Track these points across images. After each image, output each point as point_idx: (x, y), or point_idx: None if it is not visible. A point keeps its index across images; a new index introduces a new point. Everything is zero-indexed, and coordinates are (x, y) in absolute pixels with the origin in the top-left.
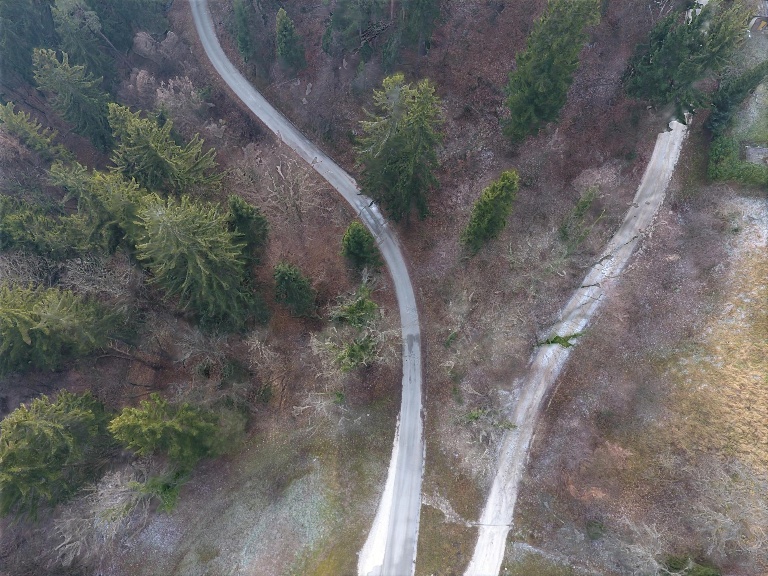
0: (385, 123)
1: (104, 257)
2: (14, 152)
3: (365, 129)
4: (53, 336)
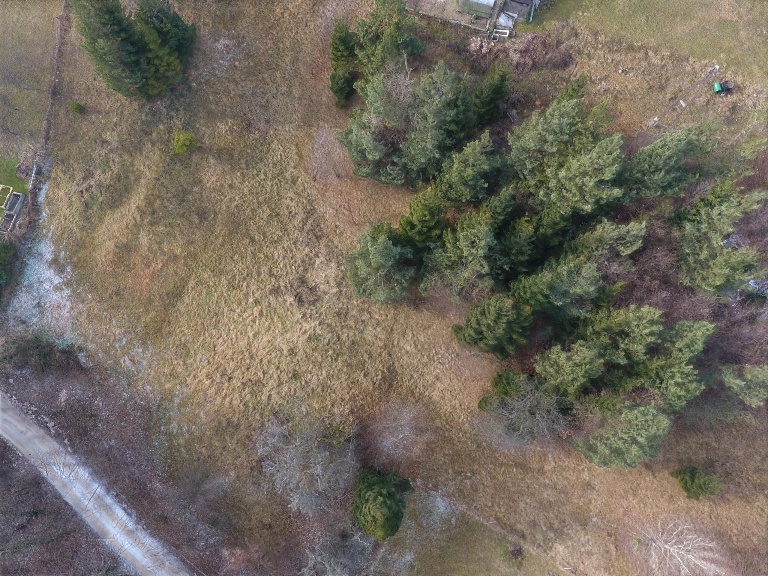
0: None
1: None
2: None
3: None
4: None
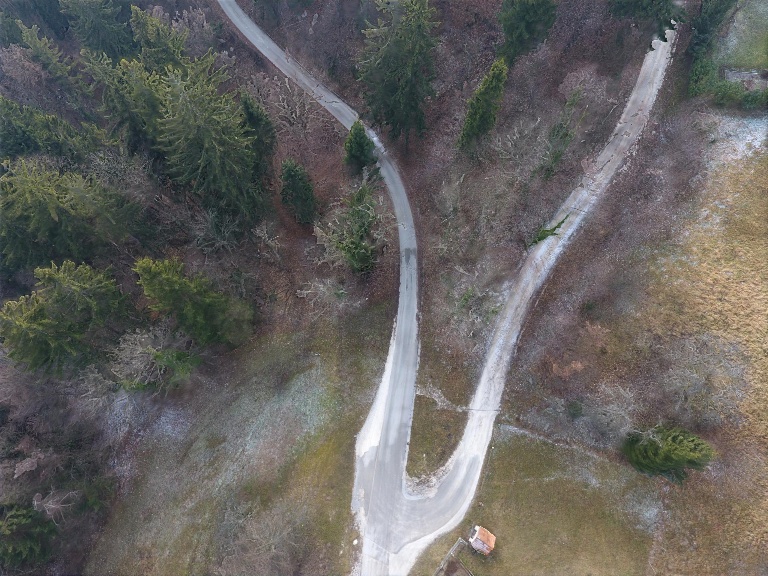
0: (386, 31)
1: (124, 157)
2: (37, 76)
3: (367, 34)
4: (77, 221)
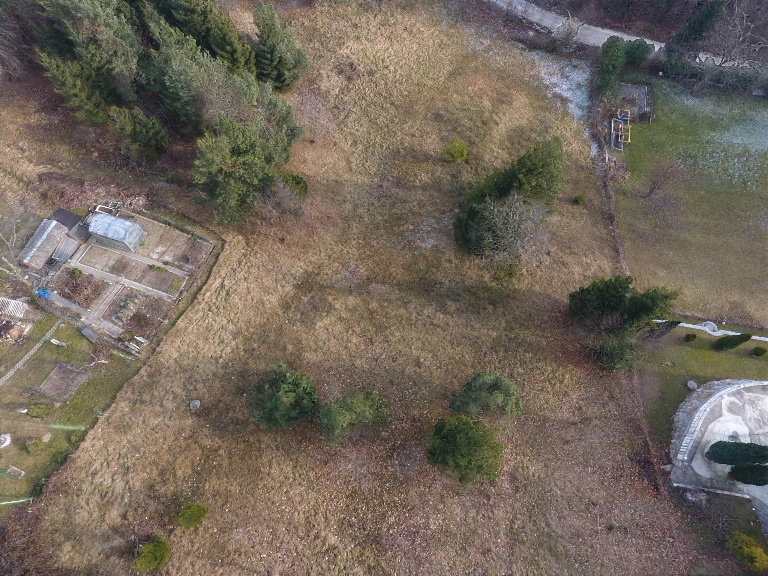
0: None
1: None
2: None
3: None
4: None
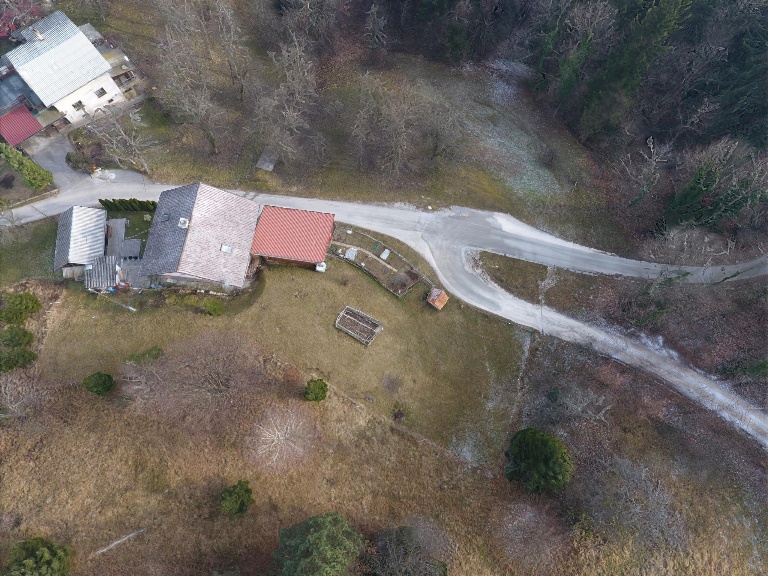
0: None
1: None
2: None
3: None
4: None
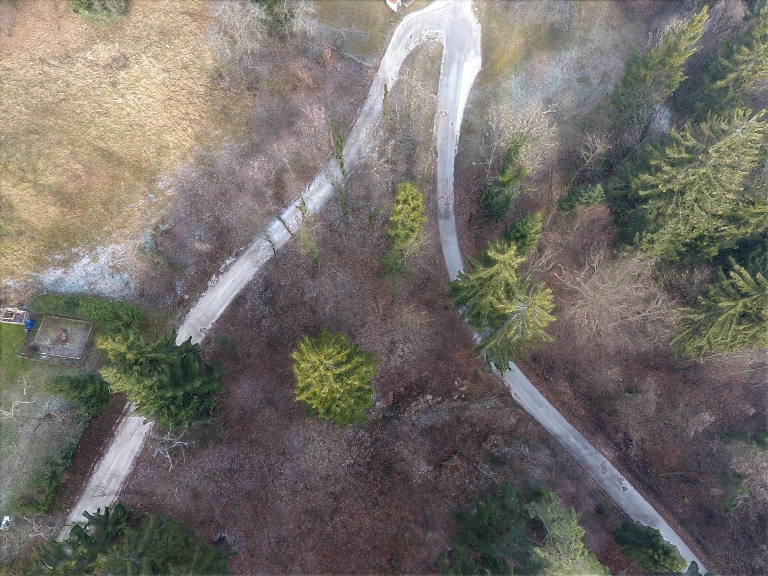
0: None
1: None
2: None
3: None
4: None
